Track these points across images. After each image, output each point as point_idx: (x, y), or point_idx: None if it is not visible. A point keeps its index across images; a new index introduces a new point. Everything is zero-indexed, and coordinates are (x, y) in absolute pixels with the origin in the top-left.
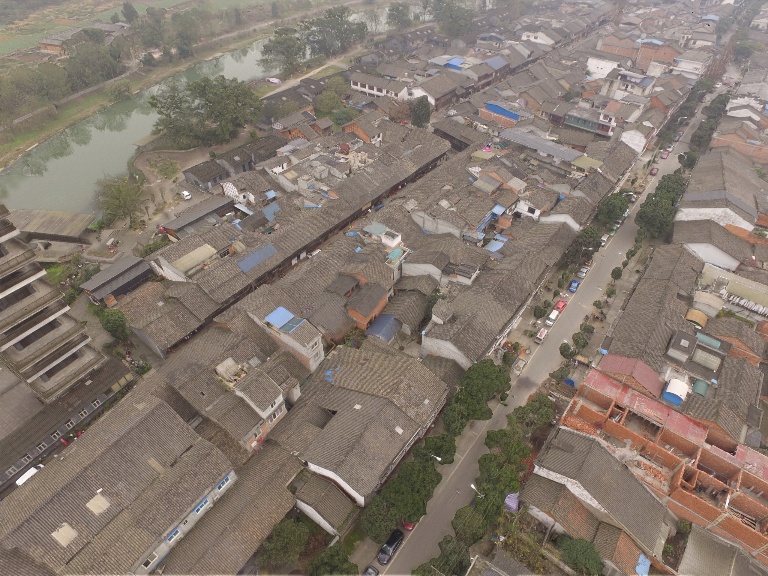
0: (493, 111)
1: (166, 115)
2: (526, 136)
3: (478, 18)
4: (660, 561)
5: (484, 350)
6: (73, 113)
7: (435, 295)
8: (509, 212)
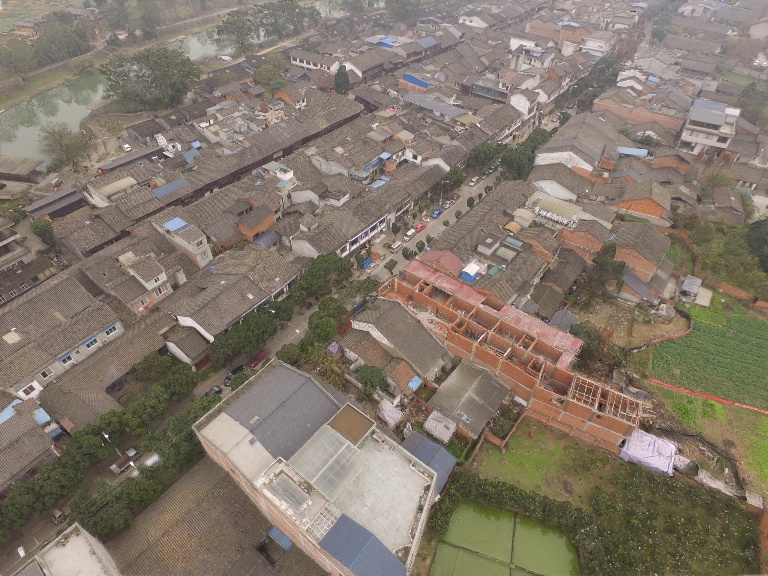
0: (409, 81)
1: (115, 82)
2: (424, 98)
3: (429, 5)
4: (429, 380)
5: (335, 248)
6: (39, 85)
7: None
8: (397, 158)
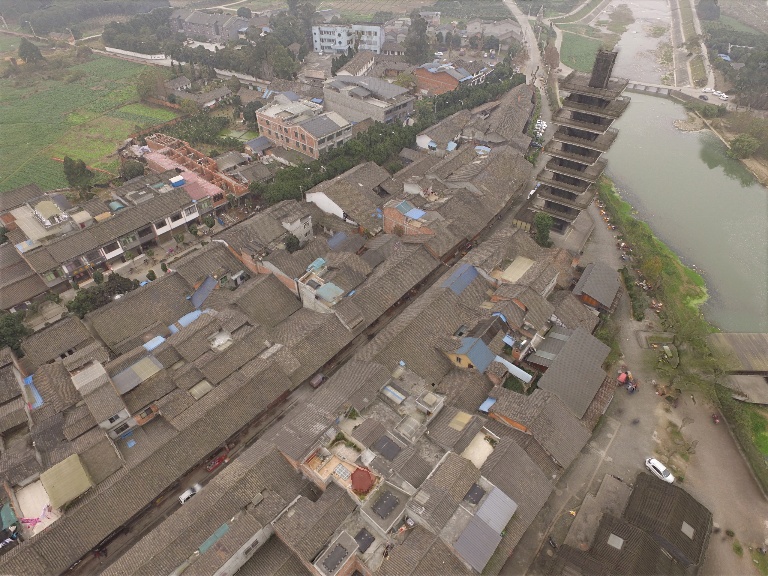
0: None
1: None
2: None
3: None
4: None
5: None
6: None
7: (290, 239)
8: None
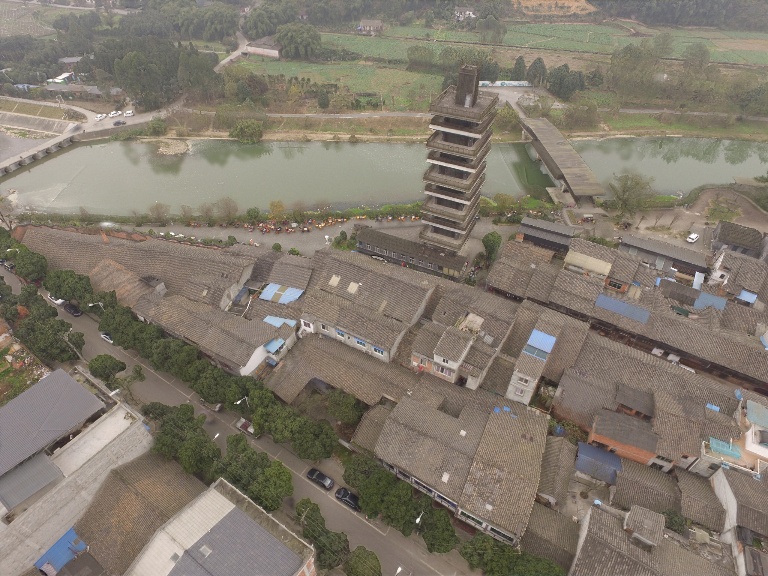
0: None
1: None
2: None
3: None
4: None
5: None
6: (746, 131)
7: (680, 518)
8: None
